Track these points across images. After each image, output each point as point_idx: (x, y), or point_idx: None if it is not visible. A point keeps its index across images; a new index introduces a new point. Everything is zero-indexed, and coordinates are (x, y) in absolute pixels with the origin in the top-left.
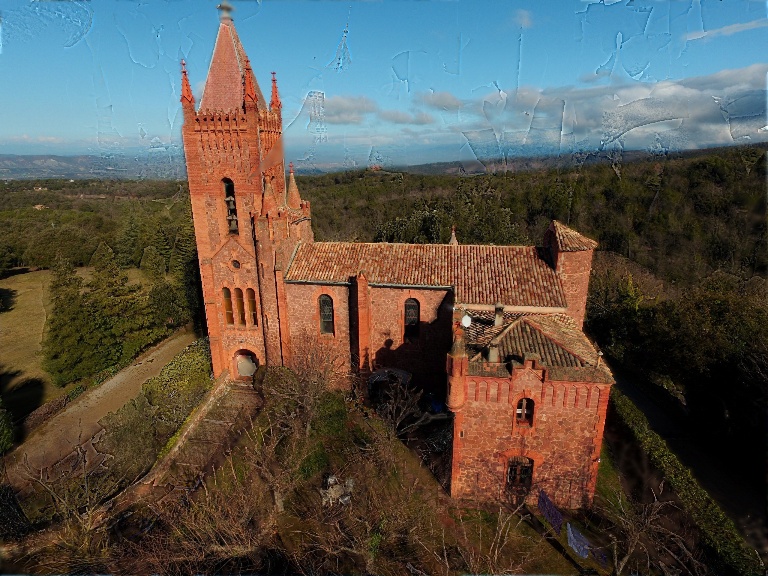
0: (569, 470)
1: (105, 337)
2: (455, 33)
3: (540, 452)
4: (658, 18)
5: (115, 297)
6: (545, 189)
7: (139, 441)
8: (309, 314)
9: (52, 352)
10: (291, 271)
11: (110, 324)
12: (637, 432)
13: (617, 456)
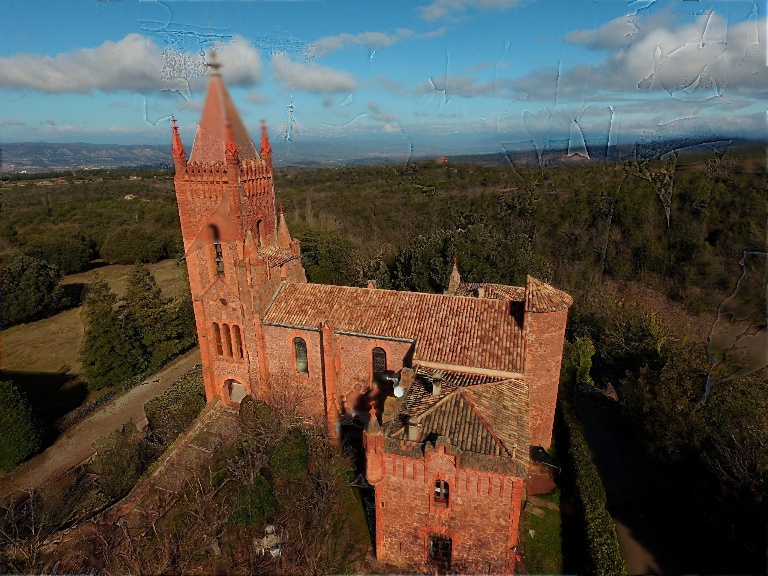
0: (487, 553)
1: (134, 348)
2: (407, 99)
3: (458, 532)
4: (722, 19)
5: (148, 309)
6: (589, 203)
7: (123, 465)
8: (285, 354)
9: (88, 360)
10: (269, 313)
11: (141, 335)
12: (589, 511)
13: (565, 533)
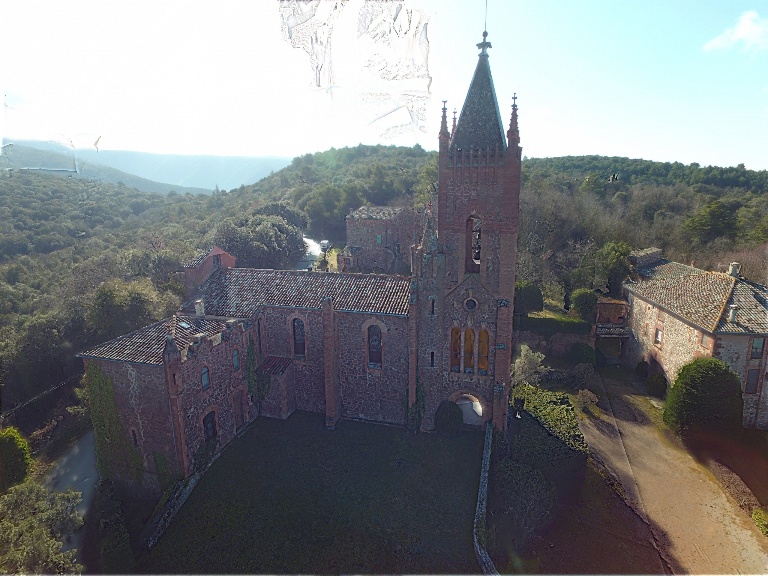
0: None
1: None
2: (308, 118)
3: None
4: None
5: None
6: None
7: None
8: None
9: None
10: None
11: None
12: None
13: None
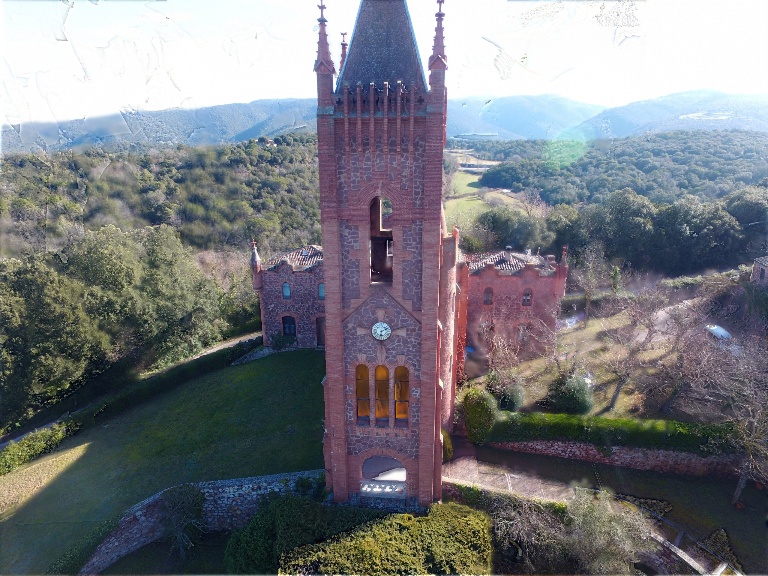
0: None
1: None
2: None
3: None
4: None
5: None
6: None
7: None
8: None
9: None
10: None
11: None
12: None
13: None
